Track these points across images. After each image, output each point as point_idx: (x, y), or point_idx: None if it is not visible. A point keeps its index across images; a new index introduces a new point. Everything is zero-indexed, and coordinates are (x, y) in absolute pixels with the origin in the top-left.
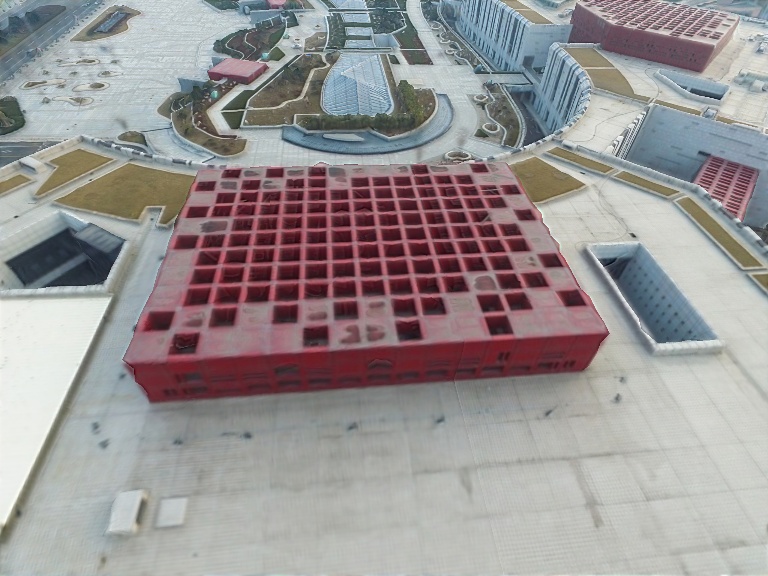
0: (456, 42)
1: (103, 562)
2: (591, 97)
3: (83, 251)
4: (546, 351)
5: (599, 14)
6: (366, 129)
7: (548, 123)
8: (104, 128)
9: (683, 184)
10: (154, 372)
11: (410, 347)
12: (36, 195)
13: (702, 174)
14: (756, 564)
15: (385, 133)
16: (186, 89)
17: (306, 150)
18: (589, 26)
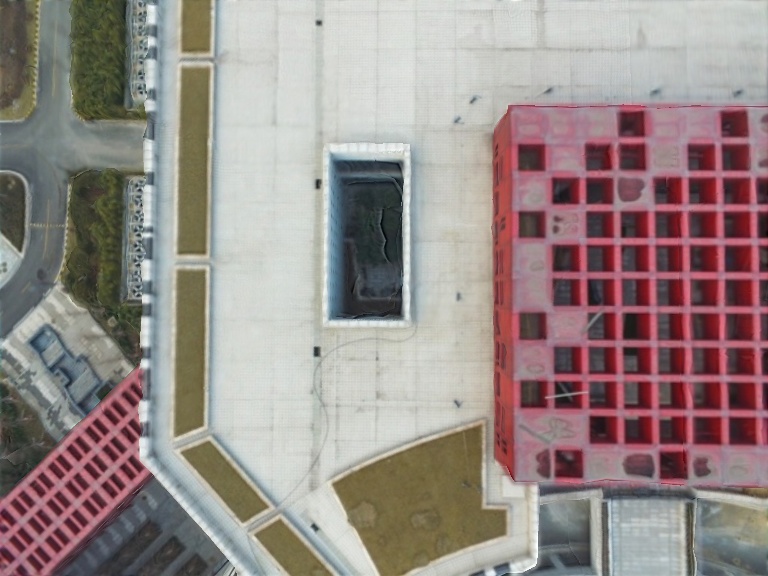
0: None
1: None
2: None
3: None
4: None
5: None
6: None
7: None
8: None
9: (162, 472)
10: None
11: None
12: None
13: (47, 567)
14: None
15: None
16: None
17: None
18: None
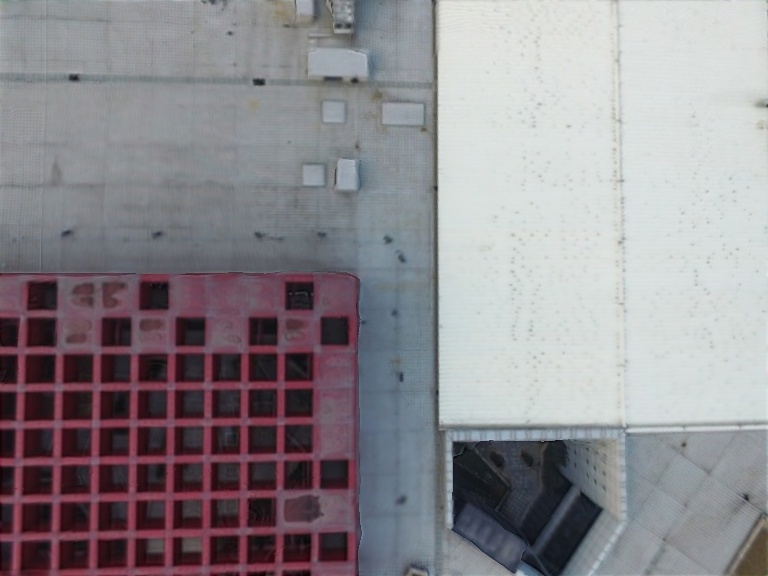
0: None
1: (357, 145)
2: None
3: None
4: None
5: None
6: None
7: None
8: None
9: None
10: None
11: (48, 275)
12: None
13: None
14: None
15: None
16: None
17: None
18: None
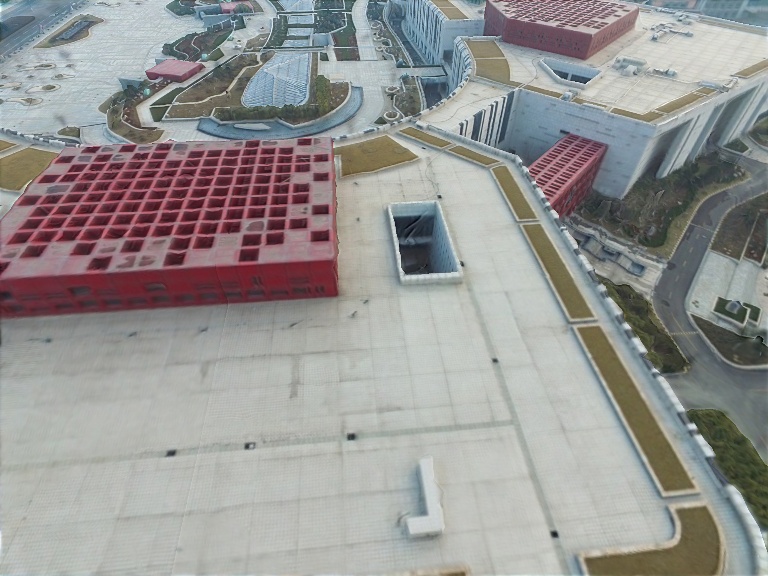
0: (389, 39)
1: None
2: (468, 84)
3: None
4: (292, 276)
5: (501, 9)
6: (274, 119)
7: None
8: (47, 124)
9: (505, 155)
10: None
11: (172, 271)
12: None
13: (552, 149)
14: (401, 421)
15: (291, 122)
16: None
17: (215, 138)
18: (494, 20)
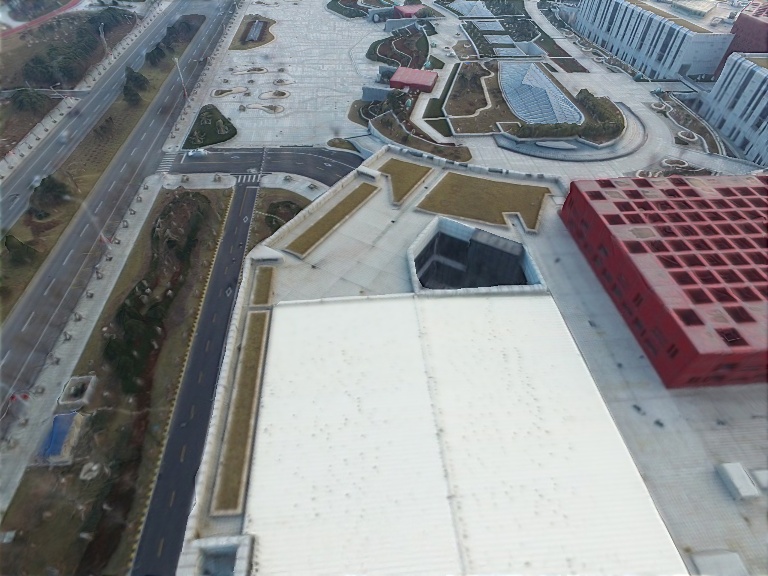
0: (597, 50)
1: (748, 521)
2: None
3: (469, 253)
4: None
5: None
6: (574, 137)
7: (724, 130)
8: (309, 135)
9: None
10: (712, 361)
11: None
12: (395, 202)
13: None
14: None
15: (592, 141)
16: (368, 97)
17: (528, 157)
18: (761, 36)
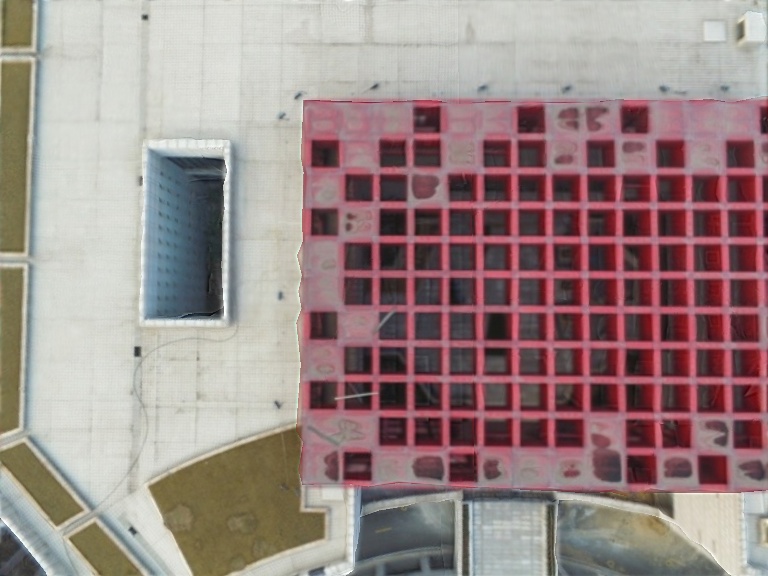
0: None
1: (756, 1)
2: None
3: None
4: None
5: None
6: None
7: None
8: None
9: None
10: None
11: None
12: None
13: None
14: None
15: None
16: None
17: None
18: None
